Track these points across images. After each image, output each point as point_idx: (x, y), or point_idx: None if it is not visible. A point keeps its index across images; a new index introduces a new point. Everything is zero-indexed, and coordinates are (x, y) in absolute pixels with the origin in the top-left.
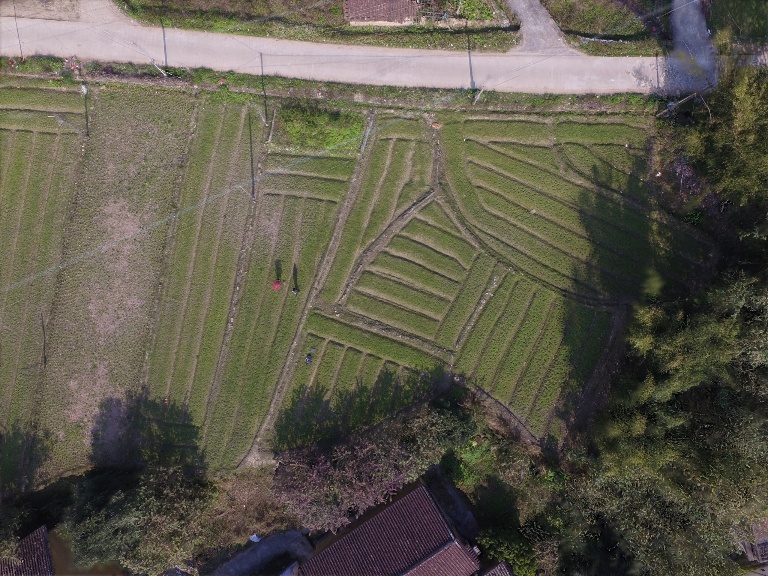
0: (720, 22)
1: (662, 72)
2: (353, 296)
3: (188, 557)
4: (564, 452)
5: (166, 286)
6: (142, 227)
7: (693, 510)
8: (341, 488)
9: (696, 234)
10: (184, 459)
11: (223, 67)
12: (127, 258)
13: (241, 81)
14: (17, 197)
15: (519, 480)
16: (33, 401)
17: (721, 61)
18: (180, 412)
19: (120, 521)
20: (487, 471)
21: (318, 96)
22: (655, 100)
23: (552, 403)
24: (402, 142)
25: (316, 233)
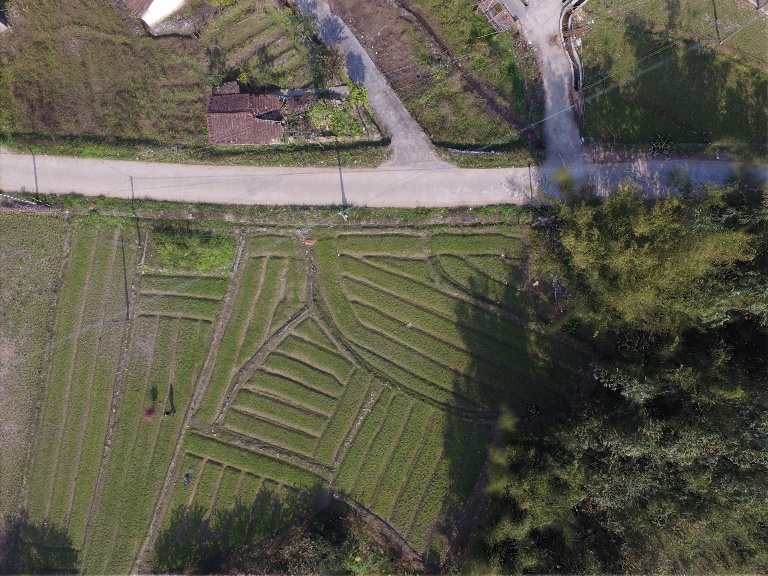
0: (593, 129)
1: (535, 182)
2: (230, 415)
3: None
4: (446, 568)
5: (43, 410)
6: (18, 352)
7: None
8: None
9: (575, 343)
10: None
11: (94, 192)
12: (4, 383)
13: (111, 205)
14: None
15: None
16: None
17: (594, 169)
18: (59, 536)
19: None
20: None
21: (189, 217)
22: (528, 211)
23: (433, 518)
24: (275, 260)
25: (191, 353)
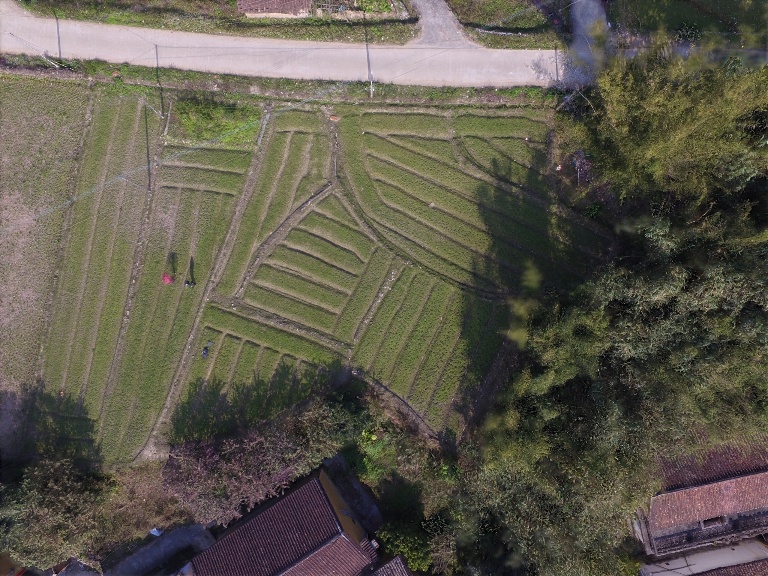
0: (620, 15)
1: (561, 65)
2: (250, 289)
3: (78, 550)
4: (462, 446)
5: (62, 279)
6: (37, 220)
7: (569, 503)
8: (227, 481)
9: (595, 228)
10: (79, 452)
11: (118, 59)
12: (22, 251)
13: (136, 73)
14: None
15: (414, 473)
16: None
17: (620, 54)
18: (76, 405)
19: None
20: (391, 465)
21: (214, 88)
22: (554, 93)
23: (450, 397)
24: (299, 135)
25: (213, 226)
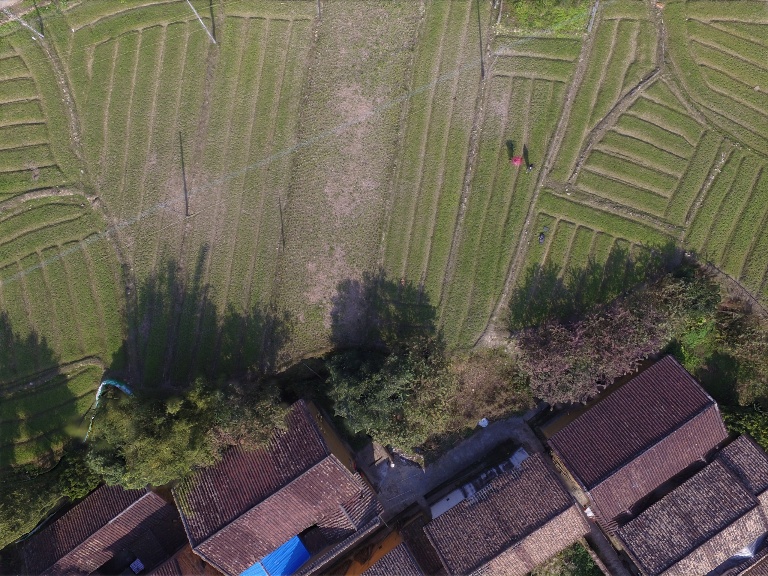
0: None
1: None
2: (583, 175)
3: (441, 430)
4: None
5: (399, 168)
6: (375, 110)
7: None
8: (600, 352)
9: None
10: None
11: None
12: (361, 141)
13: None
14: (253, 83)
15: (759, 350)
16: (272, 284)
17: None
18: (417, 293)
19: (399, 380)
20: (706, 354)
21: None
22: None
23: None
24: (627, 22)
25: (546, 113)
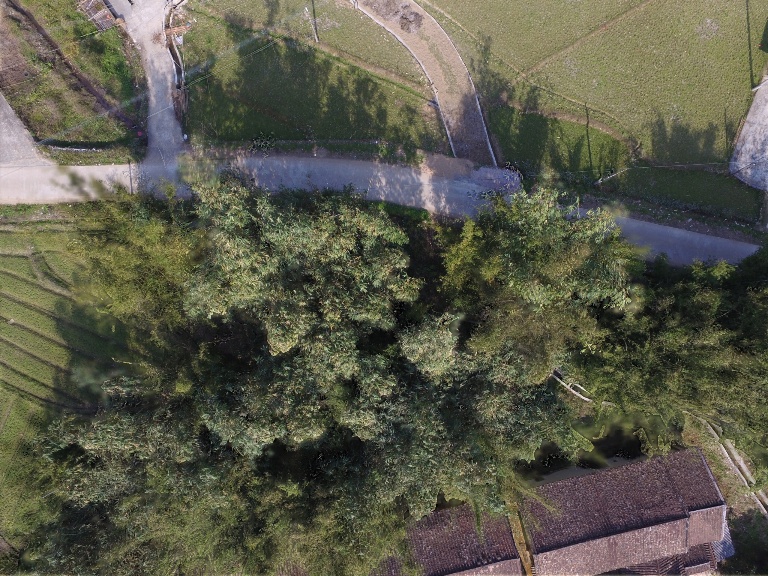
0: (196, 127)
1: (135, 179)
2: None
3: None
4: None
5: None
6: None
7: None
8: None
9: None
10: None
11: None
12: None
13: None
14: None
15: None
16: None
17: (194, 166)
18: None
19: None
20: None
21: None
22: (127, 207)
23: None
24: None
25: None
